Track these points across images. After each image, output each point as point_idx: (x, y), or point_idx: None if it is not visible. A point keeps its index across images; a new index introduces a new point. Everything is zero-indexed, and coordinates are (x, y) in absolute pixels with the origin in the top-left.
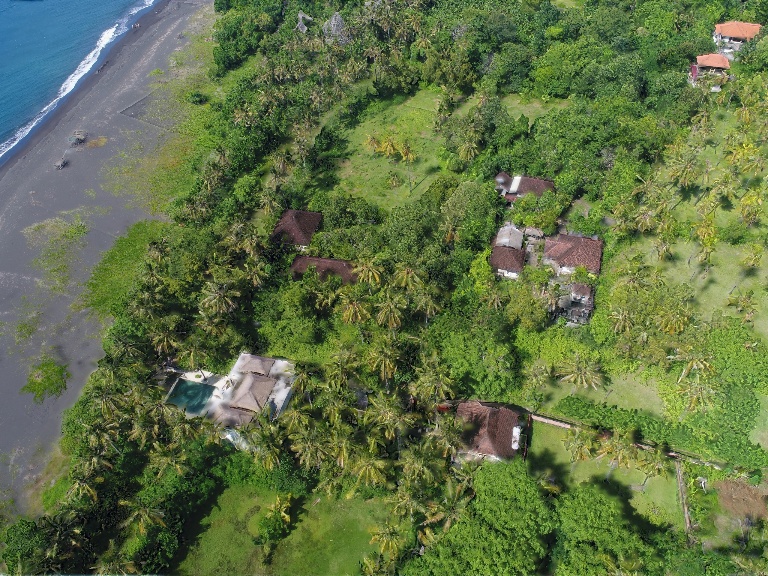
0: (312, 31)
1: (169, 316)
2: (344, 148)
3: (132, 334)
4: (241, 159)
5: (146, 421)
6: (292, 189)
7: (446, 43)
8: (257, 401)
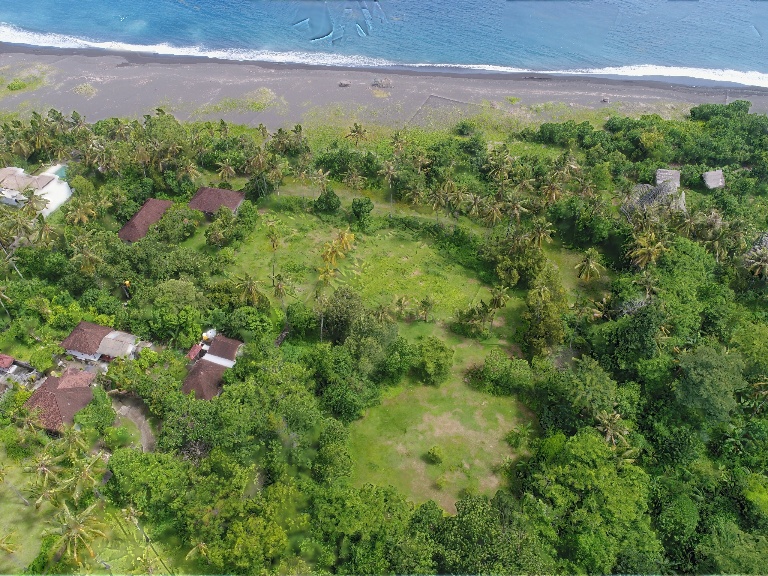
0: (690, 196)
1: (117, 144)
2: (366, 231)
3: (96, 128)
4: (327, 158)
5: (8, 138)
6: (291, 200)
7: (619, 302)
8: (3, 181)
